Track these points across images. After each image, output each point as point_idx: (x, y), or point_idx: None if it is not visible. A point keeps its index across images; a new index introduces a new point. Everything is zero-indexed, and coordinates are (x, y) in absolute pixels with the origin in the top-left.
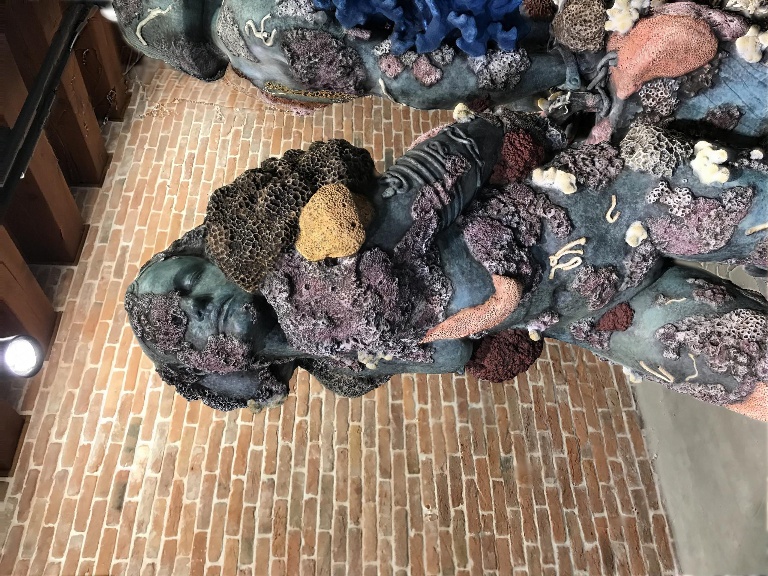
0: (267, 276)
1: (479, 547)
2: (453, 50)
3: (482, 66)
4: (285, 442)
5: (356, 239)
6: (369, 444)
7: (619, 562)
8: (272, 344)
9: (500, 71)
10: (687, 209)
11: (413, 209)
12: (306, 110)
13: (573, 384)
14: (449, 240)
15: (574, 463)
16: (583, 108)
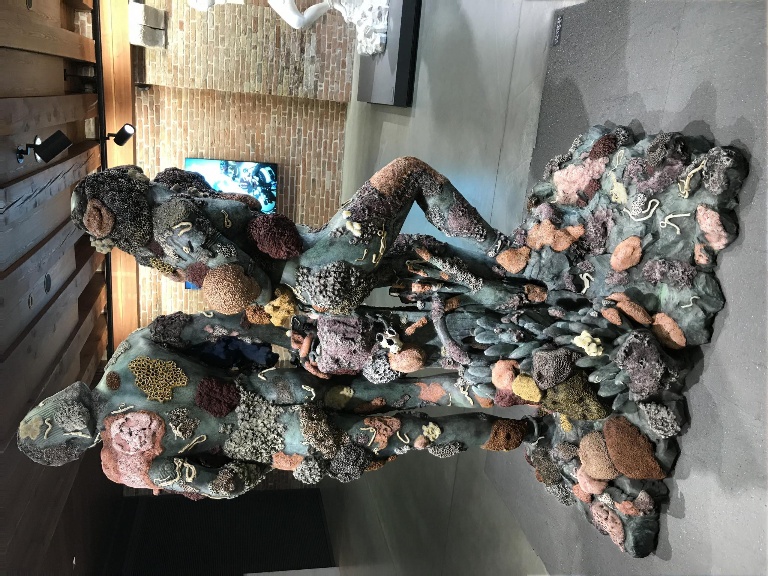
0: None
1: None
2: None
3: None
4: None
5: None
6: None
7: None
8: None
9: None
10: None
11: None
12: (146, 416)
13: None
14: None
15: None
16: (305, 319)
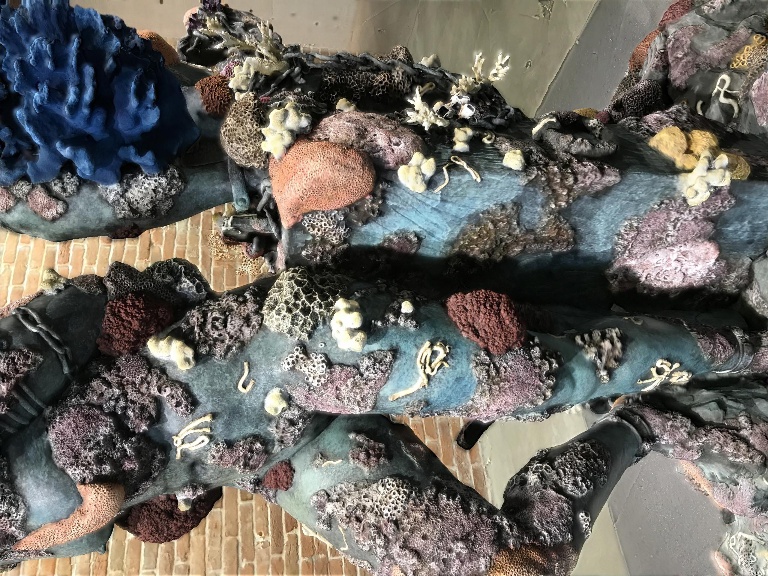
0: None
1: (312, 571)
2: (77, 179)
3: (116, 196)
4: None
5: None
6: None
7: None
8: None
9: (142, 199)
10: (322, 379)
11: None
12: None
13: None
14: (25, 444)
15: None
16: (254, 230)
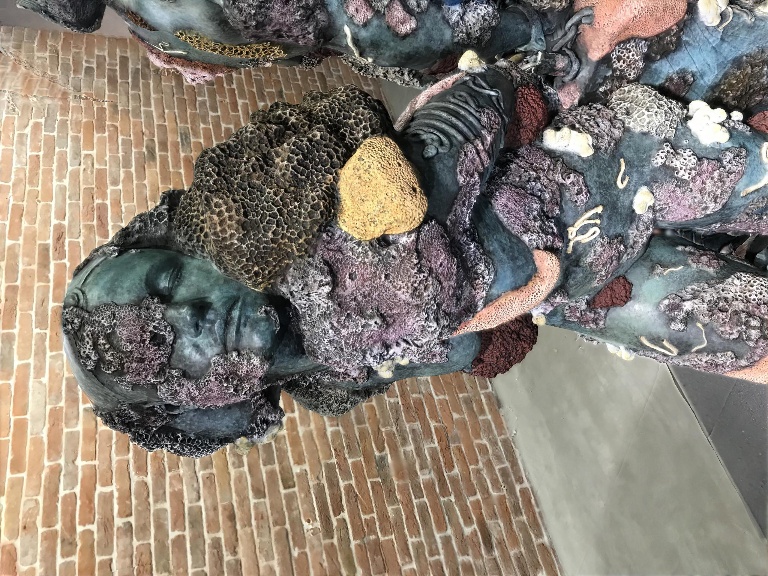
0: (292, 266)
1: (365, 553)
2: None
3: (458, 16)
4: (139, 477)
5: (421, 208)
6: (237, 464)
7: (496, 540)
8: (282, 359)
9: (474, 24)
10: (693, 171)
11: (459, 172)
12: (208, 75)
13: None
14: (481, 212)
15: (445, 451)
16: (549, 71)
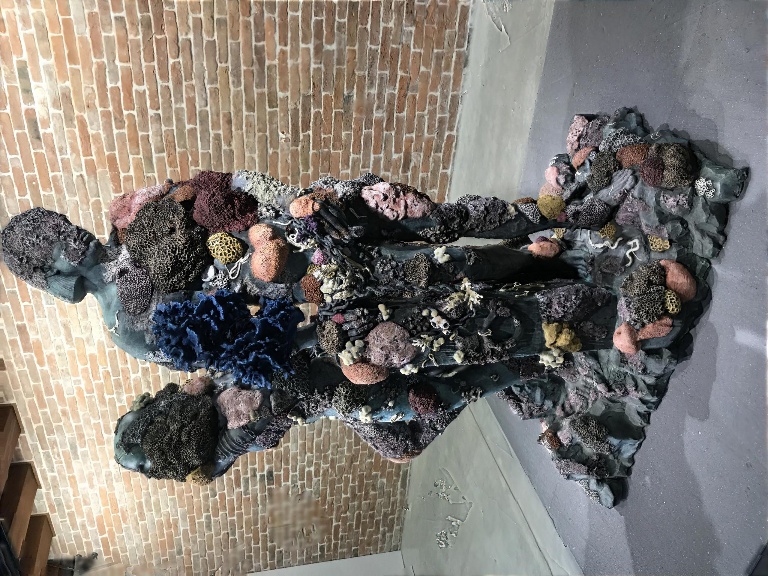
0: None
1: (318, 159)
2: None
3: None
4: (163, 84)
5: None
6: (236, 84)
7: (414, 164)
8: None
9: None
10: None
11: None
12: None
13: (419, 26)
14: None
15: (401, 98)
16: None
